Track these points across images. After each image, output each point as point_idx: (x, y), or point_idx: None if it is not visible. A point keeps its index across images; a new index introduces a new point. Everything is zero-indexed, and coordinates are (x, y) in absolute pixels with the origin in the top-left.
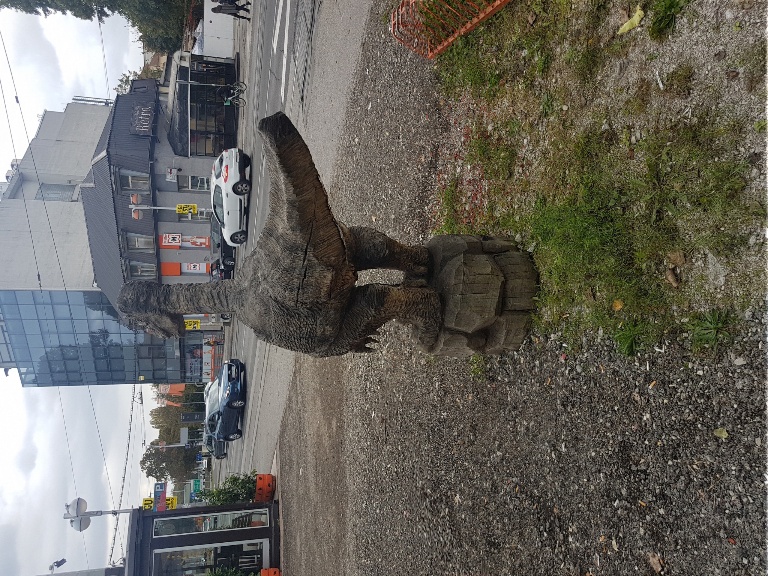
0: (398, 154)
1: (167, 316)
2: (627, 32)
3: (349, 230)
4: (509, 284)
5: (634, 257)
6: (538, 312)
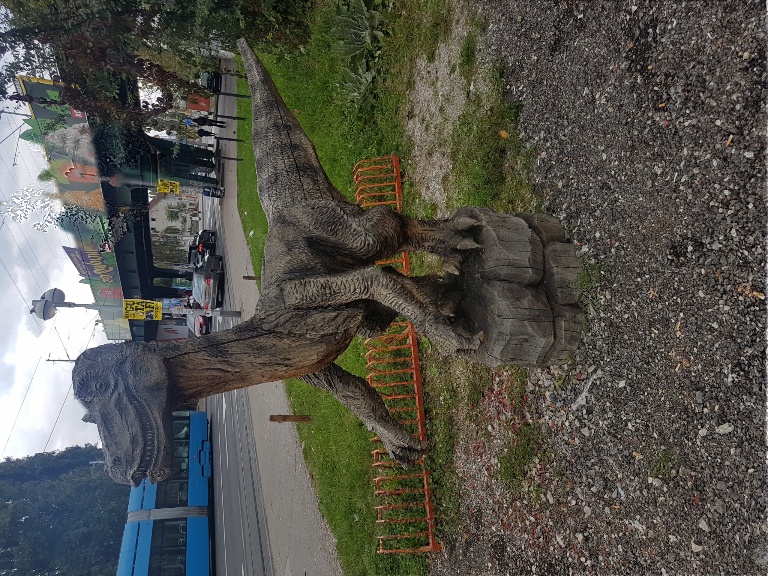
0: None
1: None
2: None
3: None
4: None
5: None
6: None
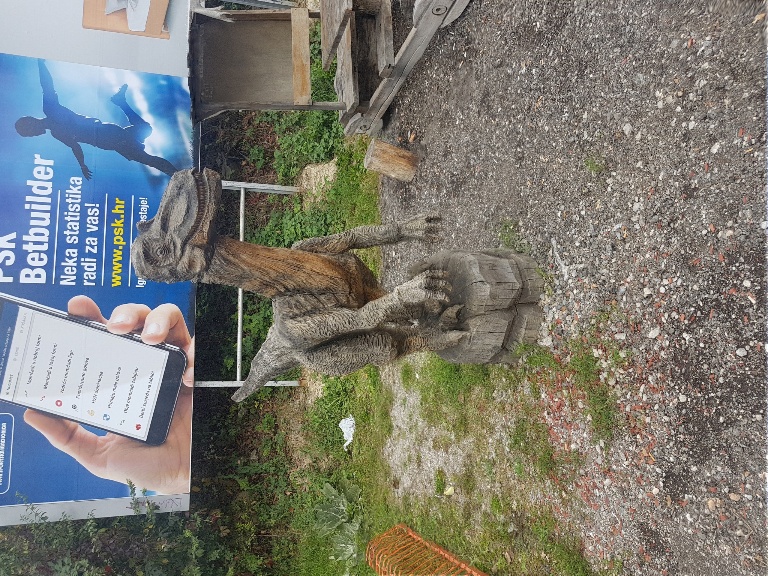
0: None
1: None
2: None
3: None
4: None
5: None
6: None
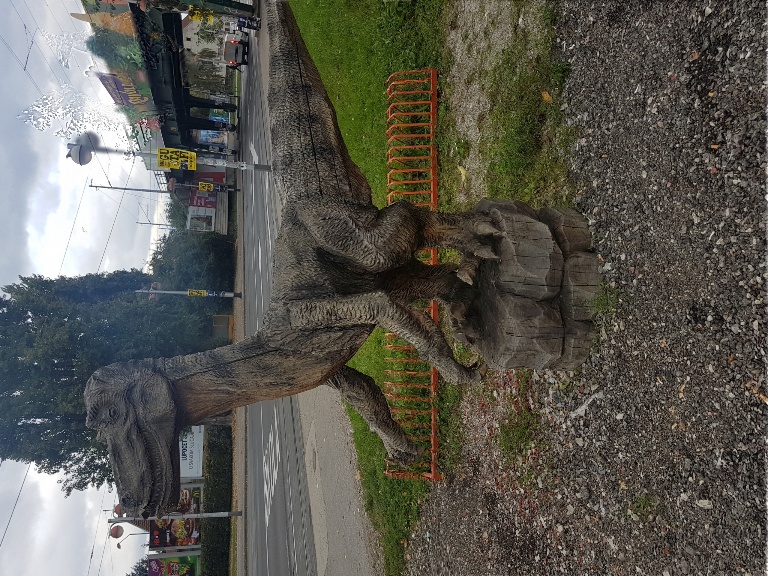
0: None
1: (162, 383)
2: (466, 179)
3: None
4: None
5: None
6: None
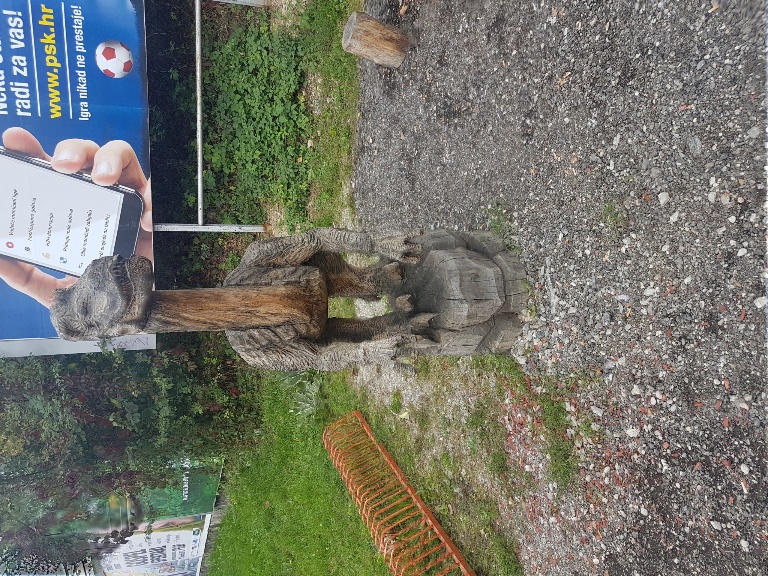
0: None
1: None
2: None
3: None
4: None
5: None
6: None
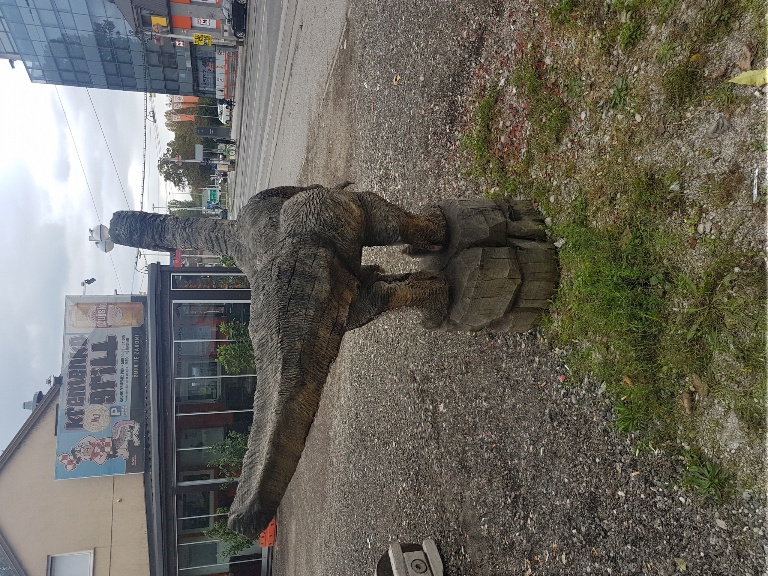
0: (438, 3)
1: (164, 246)
2: (742, 84)
3: (361, 201)
4: (525, 285)
5: (658, 350)
6: (550, 313)
